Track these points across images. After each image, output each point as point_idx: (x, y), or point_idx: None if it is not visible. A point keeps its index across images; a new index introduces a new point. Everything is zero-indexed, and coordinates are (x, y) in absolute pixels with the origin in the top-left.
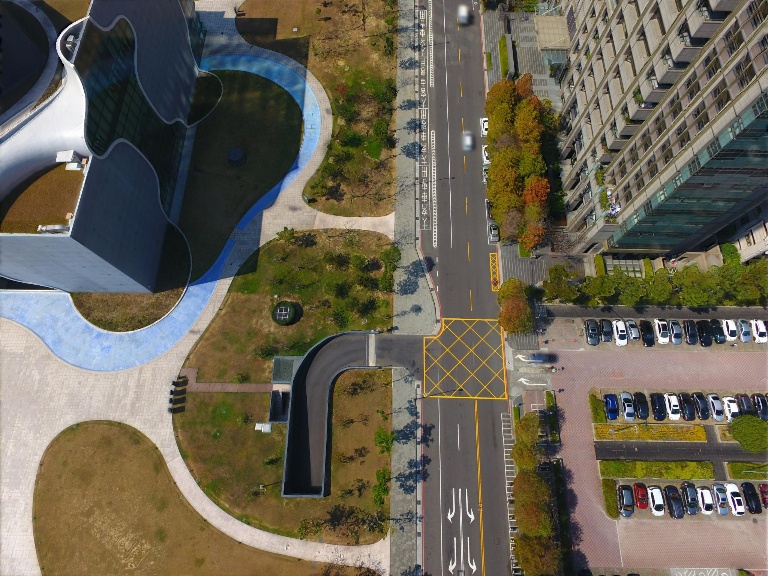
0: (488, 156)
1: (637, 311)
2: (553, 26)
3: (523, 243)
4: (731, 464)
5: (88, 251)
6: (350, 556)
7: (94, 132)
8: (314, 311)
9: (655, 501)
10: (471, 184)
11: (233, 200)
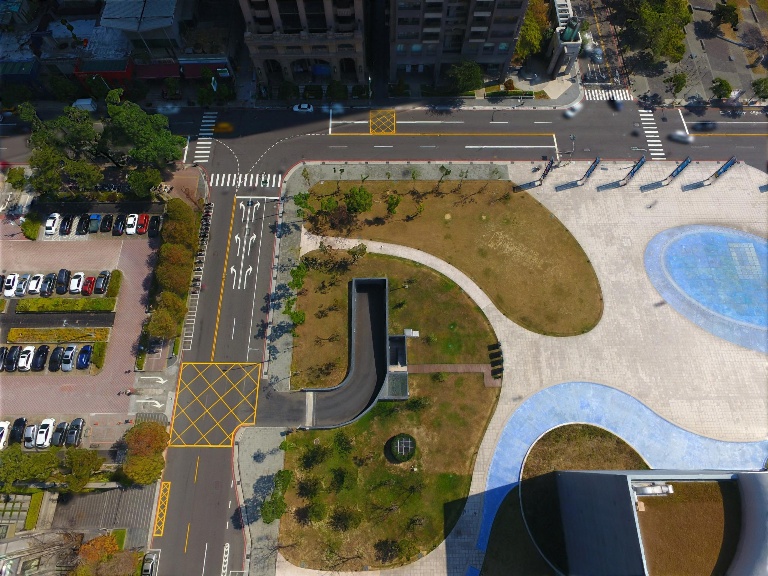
0: None
1: None
2: None
3: None
4: None
5: None
6: (332, 242)
7: None
8: (372, 453)
9: (78, 281)
10: None
11: None
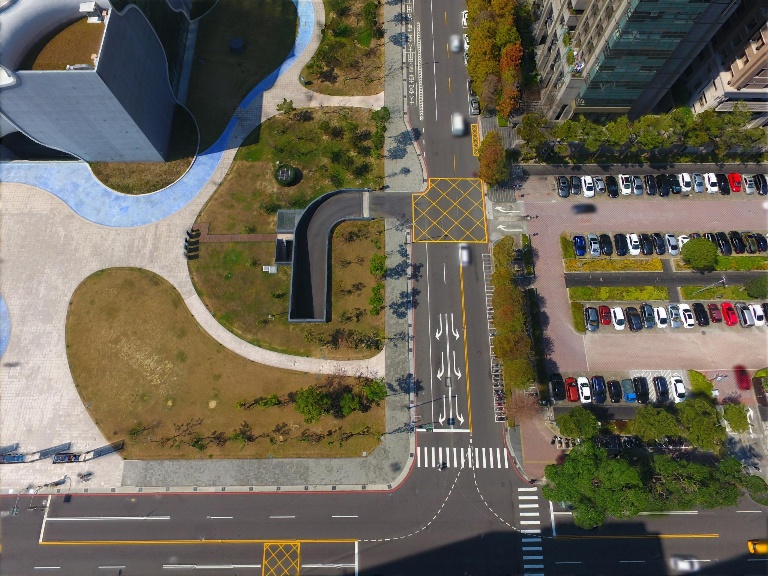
0: (469, 40)
1: (603, 169)
2: None
3: (501, 112)
4: (683, 287)
5: (110, 95)
6: (350, 368)
7: None
8: (313, 174)
9: (617, 317)
10: (454, 67)
11: (235, 84)
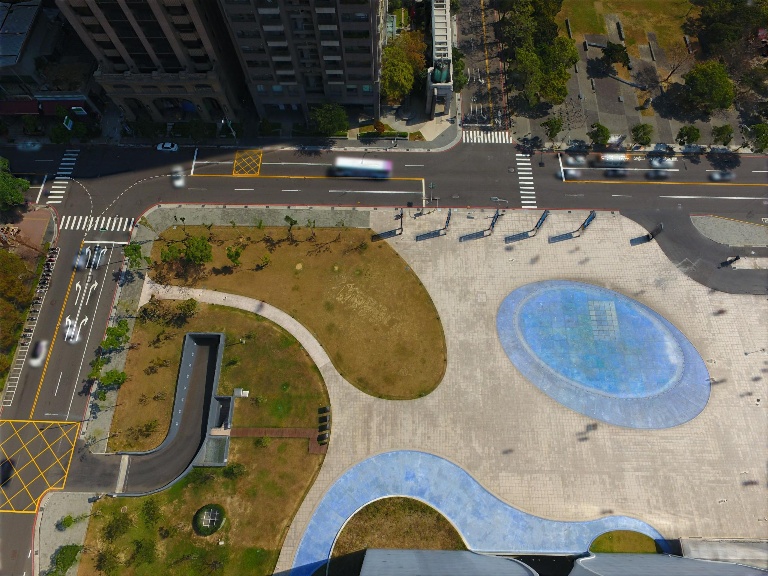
0: None
1: None
2: None
3: None
4: None
5: None
6: (174, 292)
7: None
8: (179, 523)
9: None
10: None
11: None
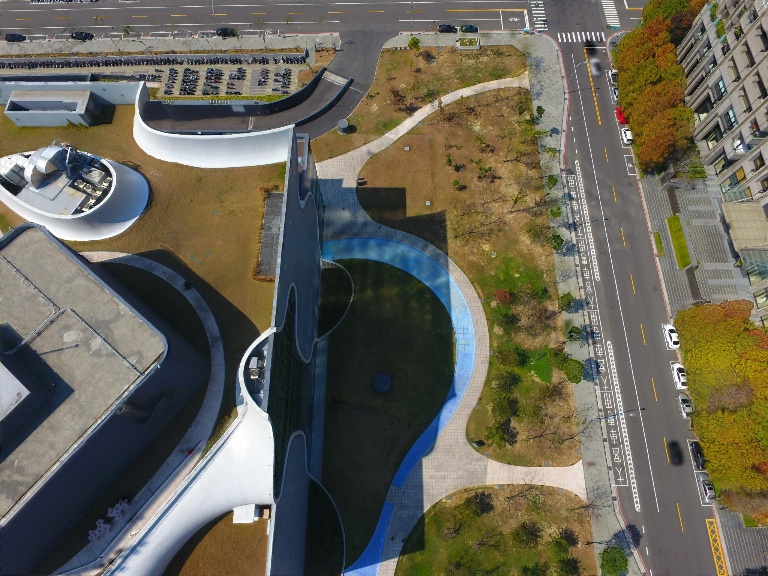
0: (690, 388)
1: None
2: (748, 217)
3: None
4: None
5: None
6: None
7: (275, 468)
8: None
9: None
10: (667, 418)
11: (384, 444)
